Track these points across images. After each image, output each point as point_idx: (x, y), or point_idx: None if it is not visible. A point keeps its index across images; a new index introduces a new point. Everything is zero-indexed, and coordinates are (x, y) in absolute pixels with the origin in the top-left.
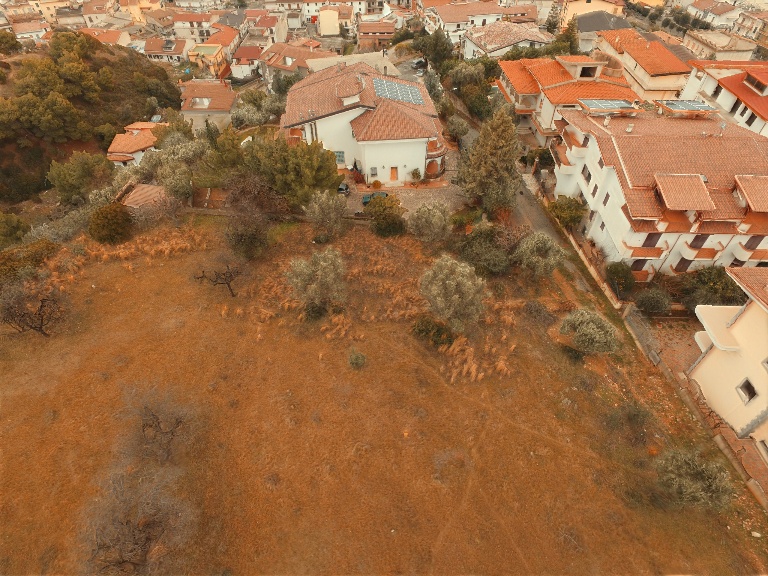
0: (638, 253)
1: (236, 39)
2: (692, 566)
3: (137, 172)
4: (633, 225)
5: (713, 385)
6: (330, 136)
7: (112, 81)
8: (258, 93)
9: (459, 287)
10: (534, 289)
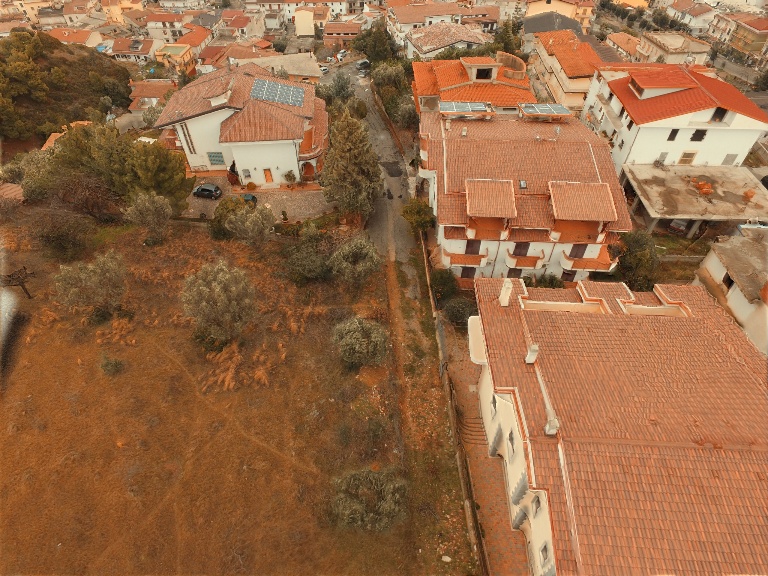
0: (456, 260)
1: (208, 39)
2: None
3: (12, 171)
4: (445, 232)
5: (485, 399)
6: (204, 137)
7: (66, 80)
8: None
9: (212, 293)
10: (352, 296)
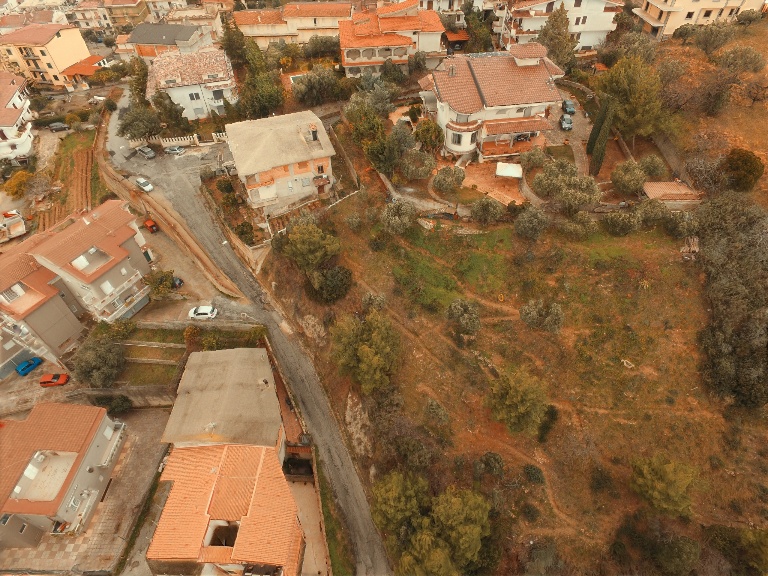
0: None
1: None
2: (766, 29)
3: None
4: (619, 11)
5: None
6: None
7: None
8: None
9: None
10: None
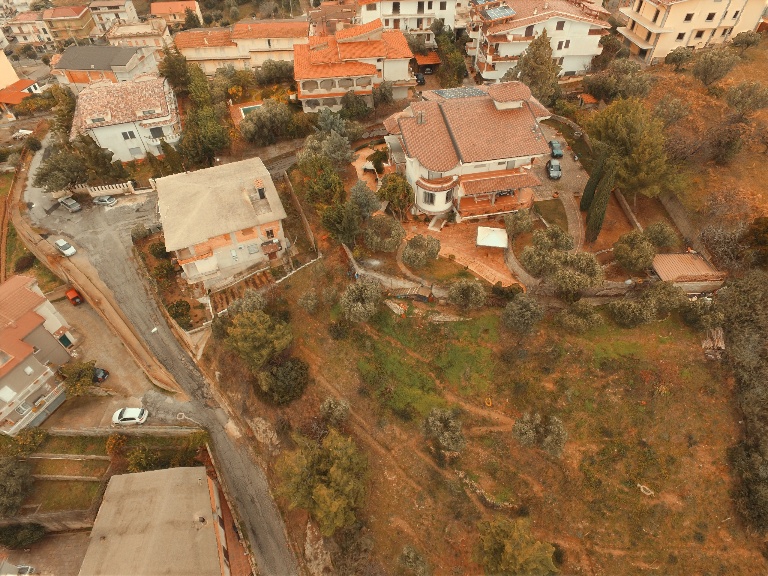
0: None
1: None
2: None
3: None
4: (605, 33)
5: None
6: None
7: None
8: (245, 319)
9: None
10: None
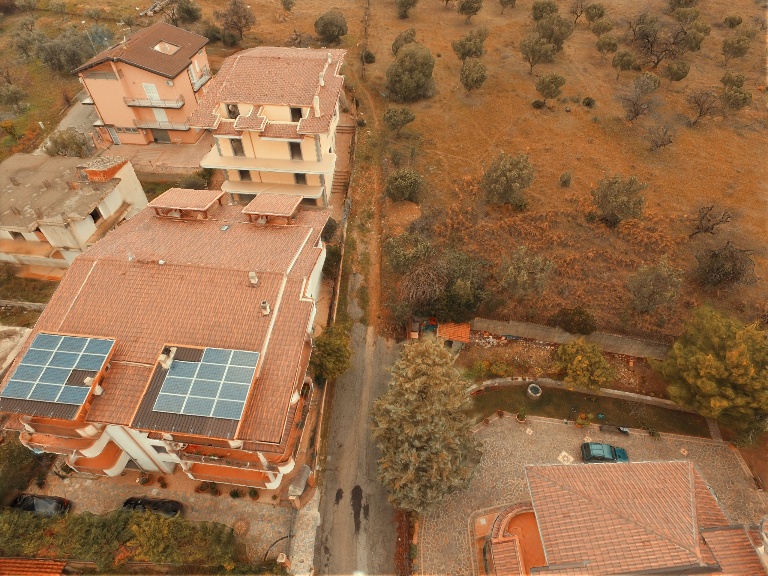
0: None
1: None
2: None
3: None
4: None
5: None
6: None
7: None
8: None
9: None
10: None
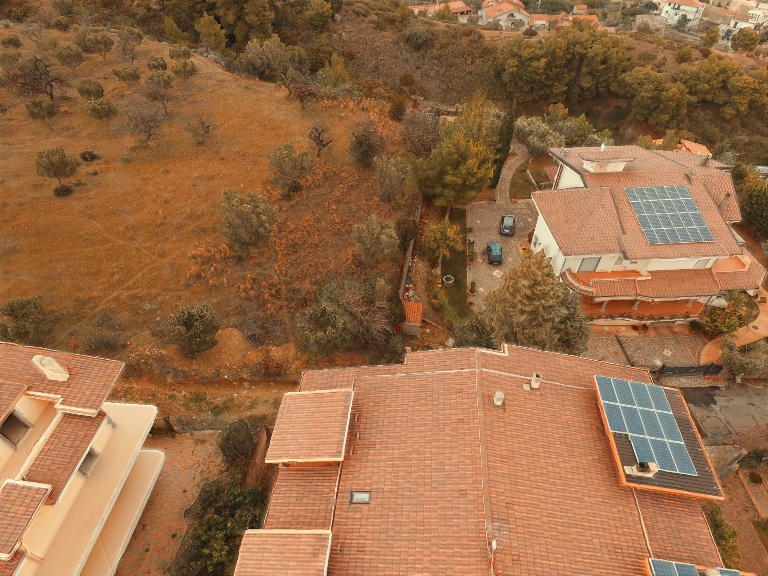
0: None
1: None
2: None
3: (500, 117)
4: None
5: None
6: None
7: None
8: None
9: None
10: None
